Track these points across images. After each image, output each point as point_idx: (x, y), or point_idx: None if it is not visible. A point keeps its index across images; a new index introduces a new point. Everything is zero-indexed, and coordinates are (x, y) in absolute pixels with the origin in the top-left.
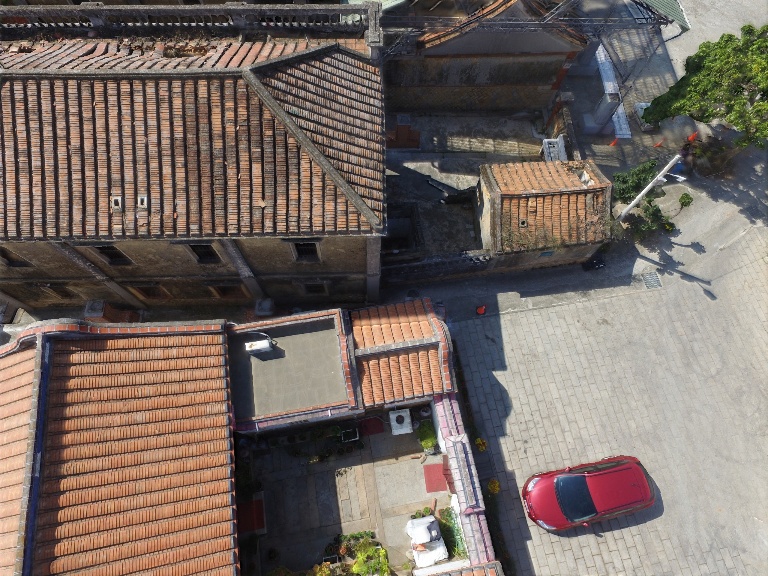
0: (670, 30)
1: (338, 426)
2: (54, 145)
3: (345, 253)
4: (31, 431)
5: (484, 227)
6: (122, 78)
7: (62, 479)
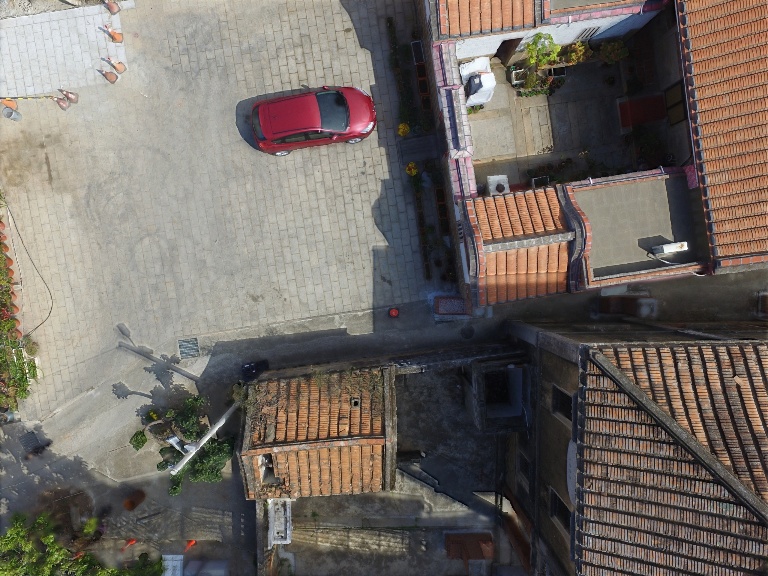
0: None
1: None
2: None
3: None
4: None
5: None
6: None
7: None
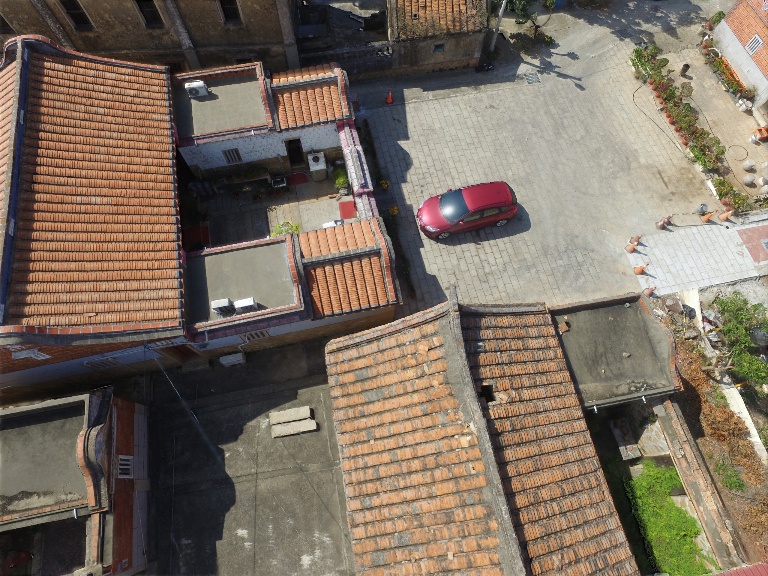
0: None
1: (268, 172)
2: None
3: (261, 12)
4: (15, 94)
5: None
6: None
7: (40, 132)
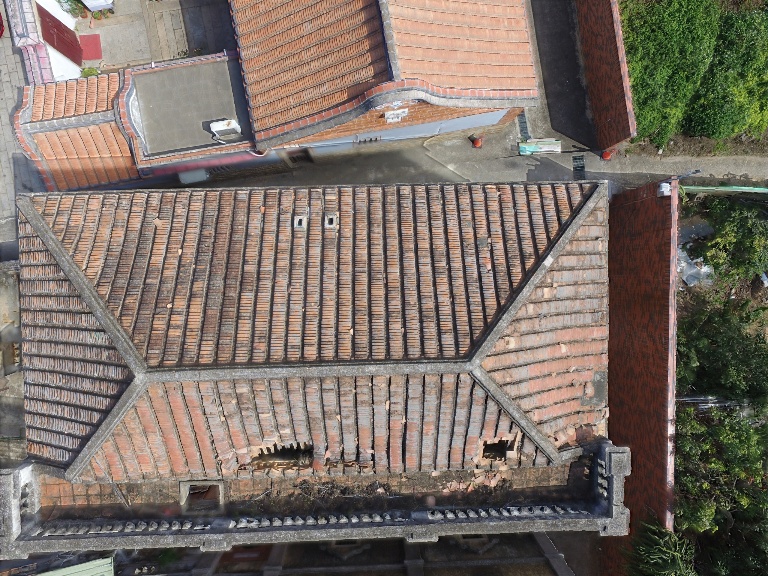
0: None
1: None
2: (403, 282)
3: None
4: None
5: (6, 307)
6: (312, 363)
7: None
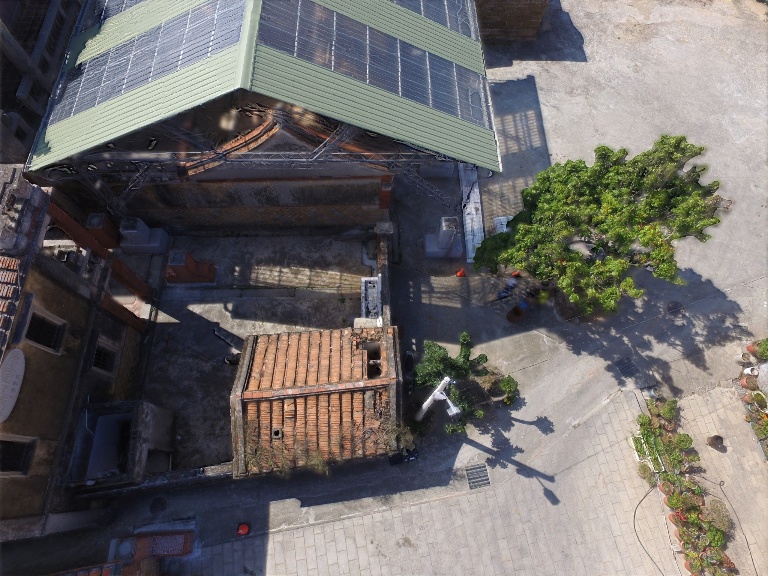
0: (553, 115)
1: None
2: None
3: None
4: None
5: None
6: None
7: None
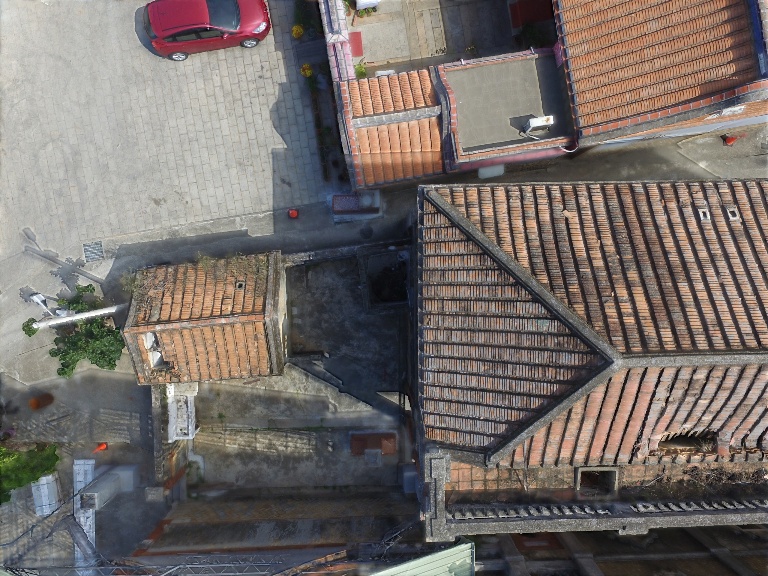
0: None
1: None
2: None
3: None
4: None
5: None
6: None
7: None
